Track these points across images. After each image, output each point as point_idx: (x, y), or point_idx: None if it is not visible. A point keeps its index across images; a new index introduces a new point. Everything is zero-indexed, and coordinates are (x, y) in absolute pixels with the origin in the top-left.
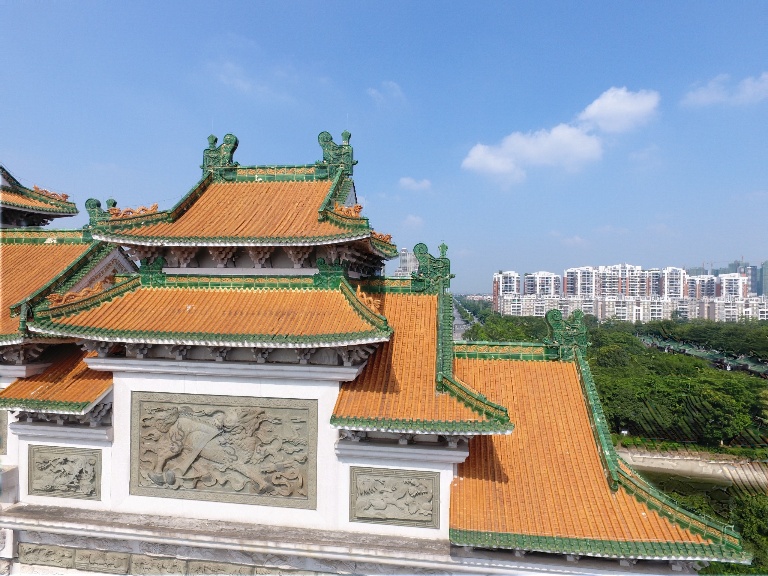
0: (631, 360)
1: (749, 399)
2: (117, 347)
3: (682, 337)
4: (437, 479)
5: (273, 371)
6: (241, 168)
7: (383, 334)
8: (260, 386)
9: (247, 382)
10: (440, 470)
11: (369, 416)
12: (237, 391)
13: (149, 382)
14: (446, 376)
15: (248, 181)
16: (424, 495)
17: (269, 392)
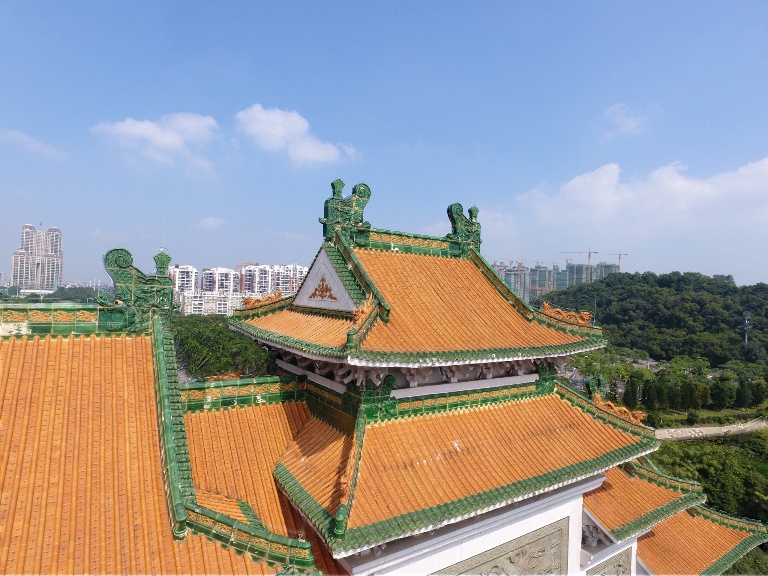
0: None
1: None
2: (301, 523)
3: None
4: (629, 553)
5: (552, 501)
6: (375, 231)
7: None
8: (529, 521)
9: (519, 521)
10: (632, 544)
11: (630, 520)
12: (510, 535)
13: (422, 564)
14: None
15: (383, 249)
16: (626, 571)
17: (536, 524)
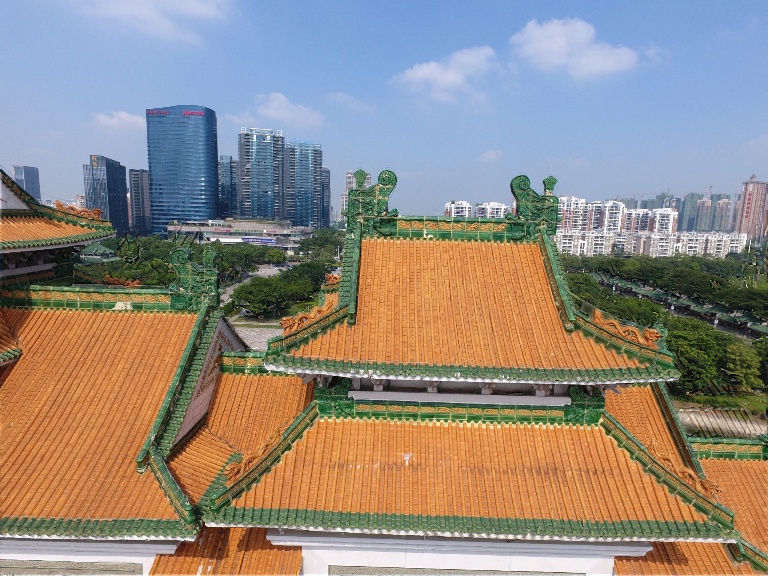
0: (600, 307)
1: (718, 353)
2: None
3: (630, 276)
4: None
5: (538, 549)
6: (403, 219)
7: (733, 536)
8: (510, 559)
9: (493, 554)
10: None
11: None
12: (478, 565)
13: (355, 555)
14: (746, 543)
15: (413, 237)
16: None
17: (522, 565)
